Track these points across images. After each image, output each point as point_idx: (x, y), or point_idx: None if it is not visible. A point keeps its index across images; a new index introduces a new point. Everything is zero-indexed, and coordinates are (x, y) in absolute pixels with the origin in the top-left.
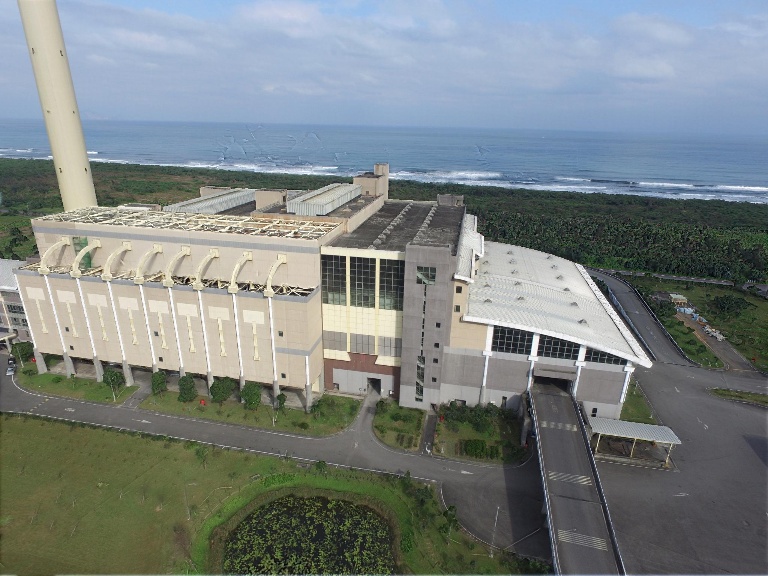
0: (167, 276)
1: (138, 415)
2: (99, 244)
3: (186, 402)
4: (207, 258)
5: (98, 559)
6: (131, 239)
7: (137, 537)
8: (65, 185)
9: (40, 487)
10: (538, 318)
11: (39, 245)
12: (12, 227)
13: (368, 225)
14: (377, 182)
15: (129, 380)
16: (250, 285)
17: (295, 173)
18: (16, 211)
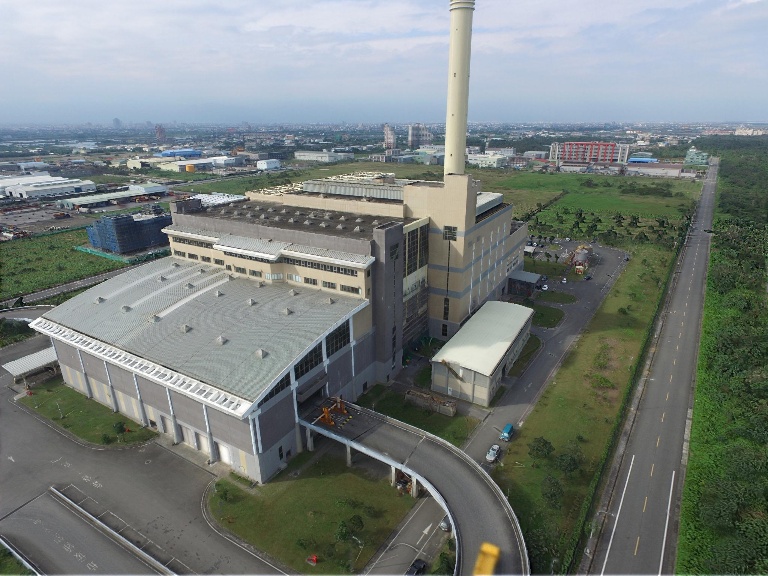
0: None
1: None
2: None
3: None
4: None
5: None
6: None
7: None
8: None
9: None
10: (131, 279)
11: None
12: None
13: (305, 209)
14: (404, 189)
15: None
16: None
17: None
18: None
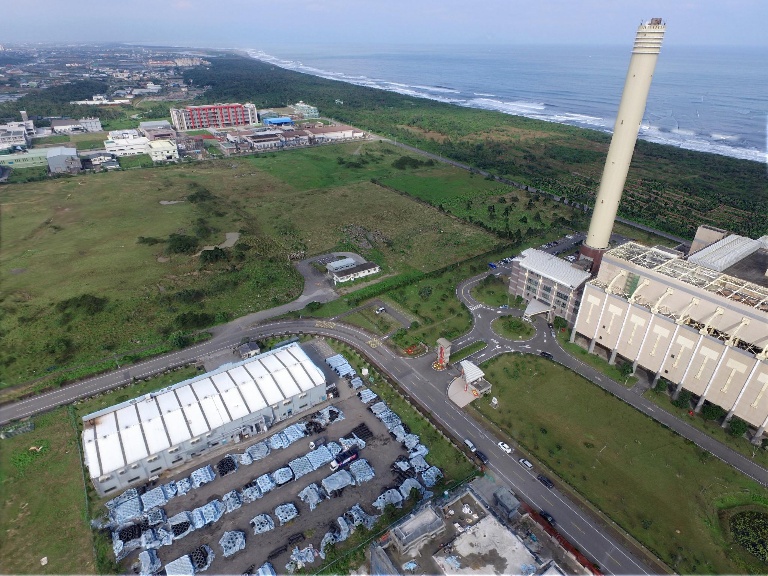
0: (705, 328)
1: (644, 402)
2: (648, 283)
3: (677, 407)
4: (742, 325)
5: (650, 487)
6: (676, 288)
7: (670, 486)
8: (601, 211)
9: (602, 426)
10: None
11: (601, 268)
12: (497, 194)
13: None
14: None
15: (633, 373)
16: (767, 352)
17: (731, 156)
18: (493, 176)
